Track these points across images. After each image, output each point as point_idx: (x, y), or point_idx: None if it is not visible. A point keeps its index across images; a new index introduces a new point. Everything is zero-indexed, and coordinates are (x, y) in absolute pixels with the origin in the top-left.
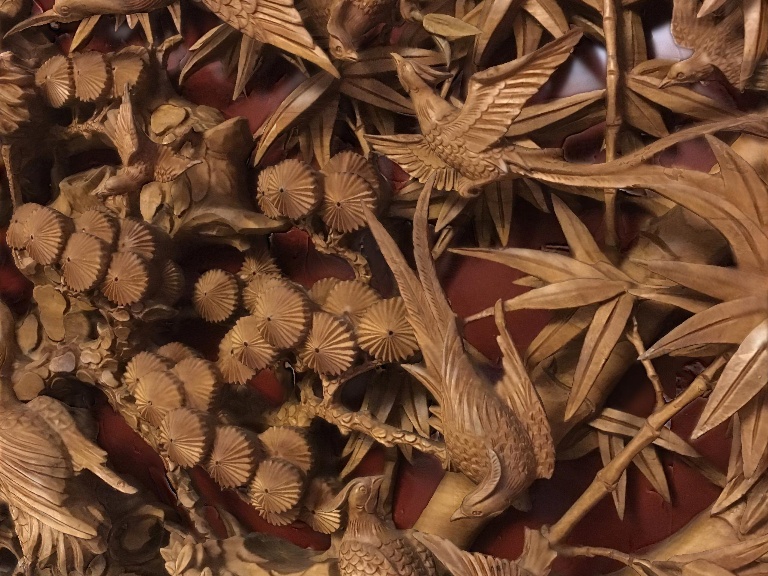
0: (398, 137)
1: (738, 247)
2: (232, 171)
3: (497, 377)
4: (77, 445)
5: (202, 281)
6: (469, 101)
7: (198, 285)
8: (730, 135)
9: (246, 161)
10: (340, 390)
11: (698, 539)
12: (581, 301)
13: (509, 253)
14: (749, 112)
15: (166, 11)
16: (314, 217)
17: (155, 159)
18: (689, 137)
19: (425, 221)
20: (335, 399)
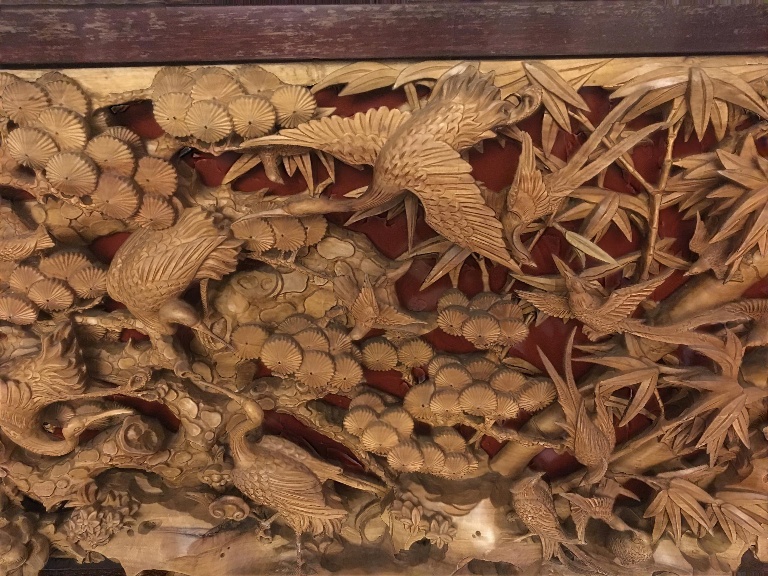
0: (540, 295)
1: (725, 371)
2: (395, 288)
3: (593, 416)
4: (318, 467)
5: (369, 349)
6: (609, 302)
7: (366, 351)
8: None
9: None
10: None
11: (652, 451)
12: None
13: (604, 359)
14: None
15: (321, 165)
16: None
17: None
18: (713, 322)
19: None
20: None
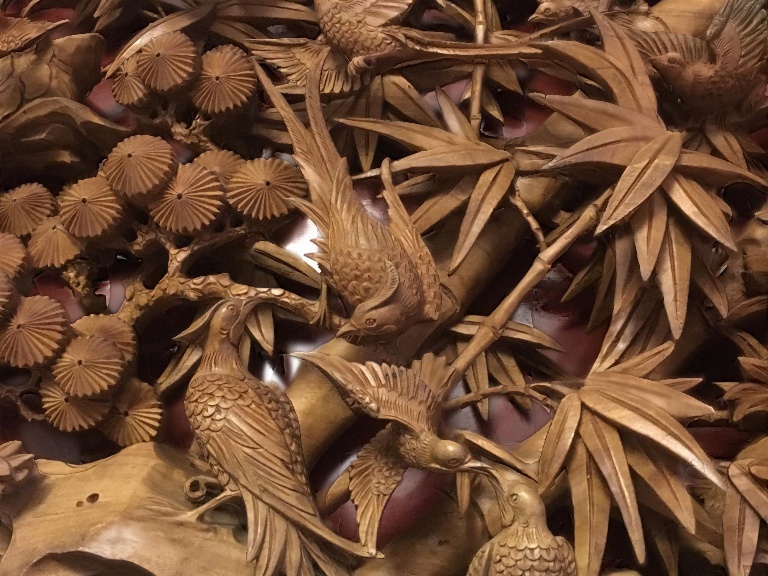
0: (283, 39)
1: (620, 94)
2: (73, 89)
3: None
4: None
5: (10, 194)
6: None
7: (3, 198)
8: None
9: (86, 93)
10: (188, 264)
11: None
12: (469, 160)
13: (396, 124)
14: None
15: None
16: (178, 107)
17: (3, 29)
18: (571, 22)
19: (318, 81)
20: (183, 269)
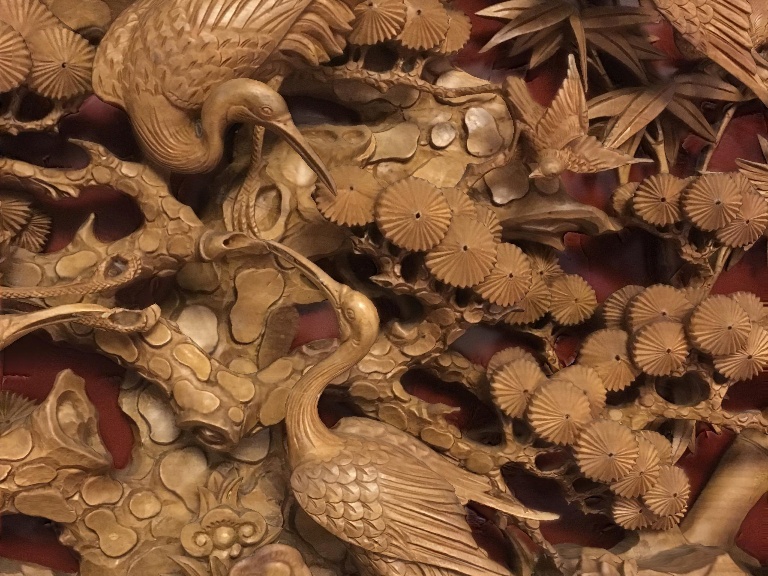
0: None
1: None
2: None
3: None
4: (451, 474)
5: None
6: None
7: None
8: None
9: None
10: None
11: None
12: None
13: None
14: None
15: None
16: None
17: None
18: None
19: None
20: None
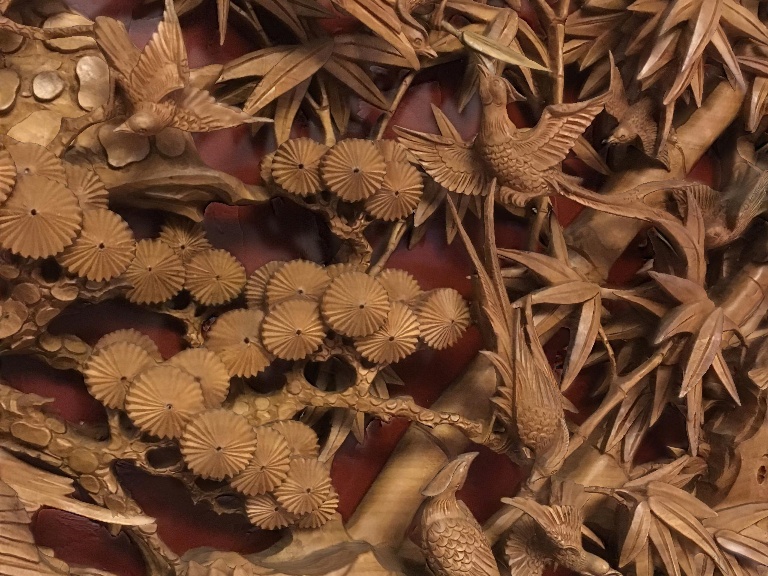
0: (433, 136)
1: (692, 268)
2: None
3: None
4: (20, 475)
5: None
6: (542, 126)
7: None
8: (595, 180)
9: None
10: None
11: (596, 471)
12: (582, 299)
13: (532, 256)
14: (610, 167)
15: None
16: None
17: (179, 100)
18: (665, 188)
19: (493, 223)
20: None
